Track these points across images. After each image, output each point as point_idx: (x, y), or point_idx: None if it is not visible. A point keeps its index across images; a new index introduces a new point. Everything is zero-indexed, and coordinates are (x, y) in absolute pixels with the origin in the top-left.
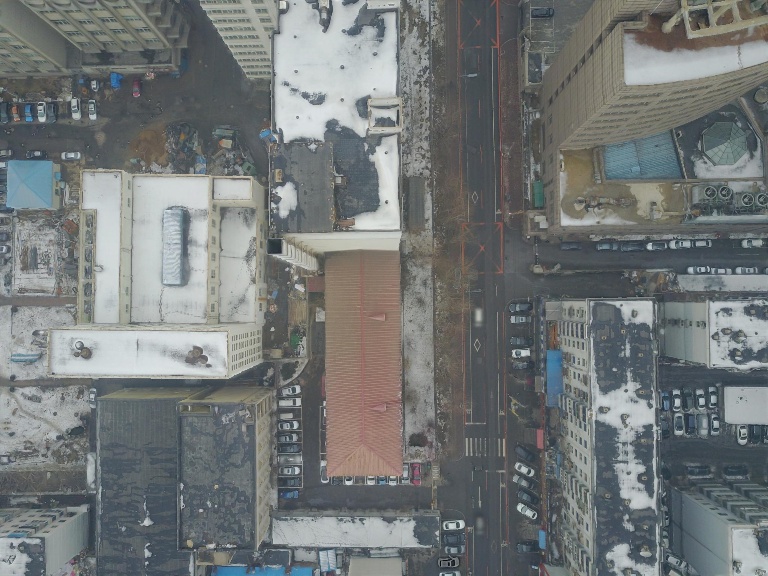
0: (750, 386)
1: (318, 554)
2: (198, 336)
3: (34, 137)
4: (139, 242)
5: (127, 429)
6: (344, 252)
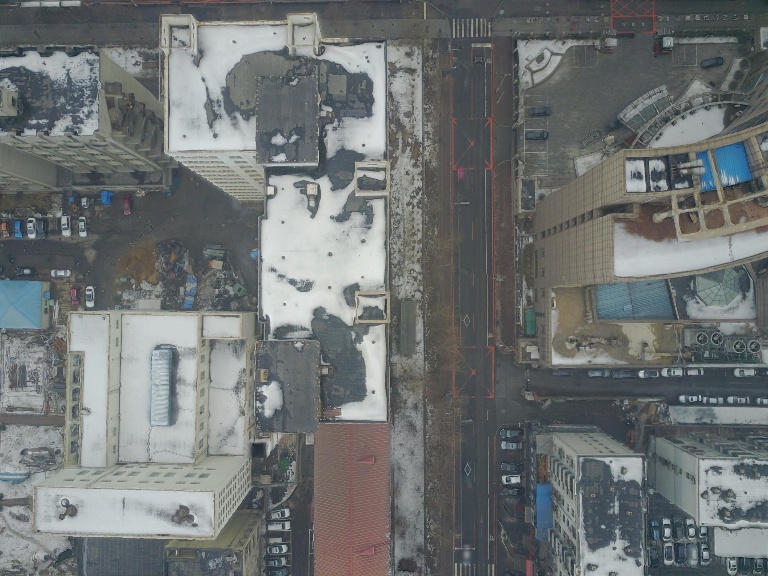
0: None
1: None
2: (185, 495)
3: (24, 253)
4: (127, 380)
5: (114, 565)
6: None
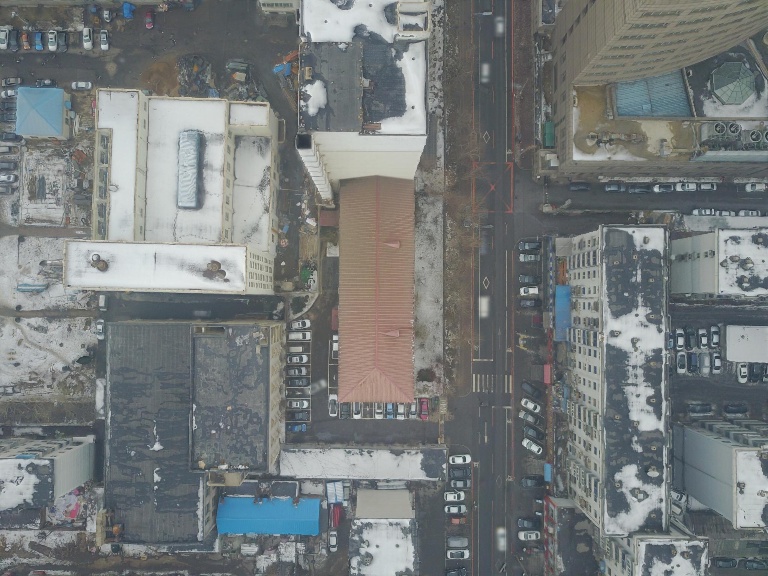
0: (751, 325)
1: (325, 486)
2: (216, 251)
3: (44, 66)
4: (154, 165)
5: (138, 354)
6: (360, 179)
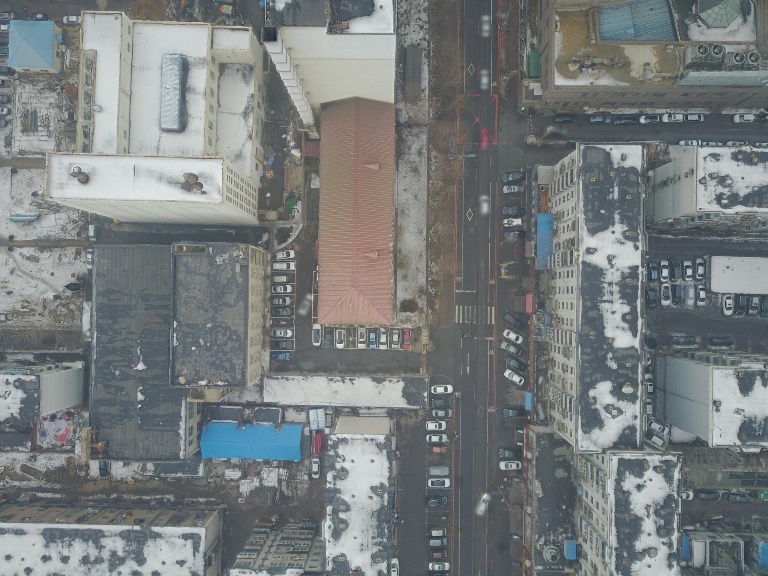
0: (737, 256)
1: (308, 413)
2: (194, 163)
3: (36, 1)
4: (138, 88)
5: (123, 275)
6: (340, 101)
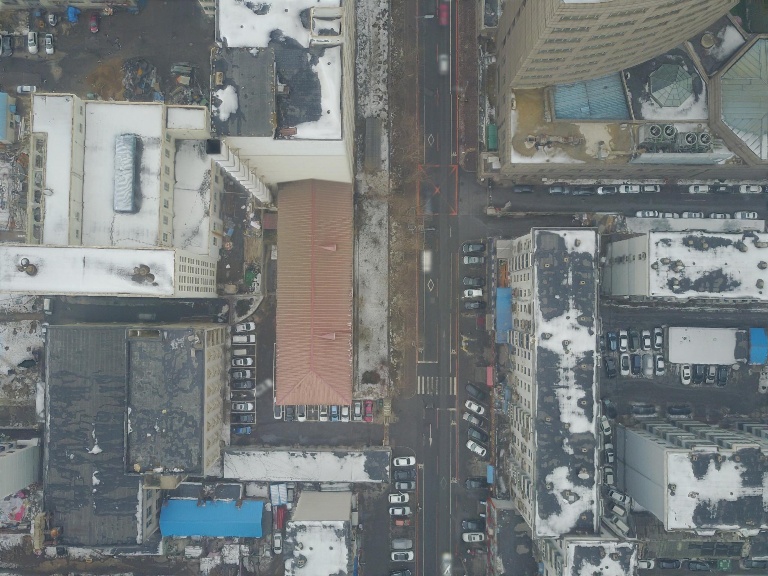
0: (694, 327)
1: (269, 488)
2: (145, 255)
3: None
4: (91, 169)
5: (77, 357)
6: (296, 182)
